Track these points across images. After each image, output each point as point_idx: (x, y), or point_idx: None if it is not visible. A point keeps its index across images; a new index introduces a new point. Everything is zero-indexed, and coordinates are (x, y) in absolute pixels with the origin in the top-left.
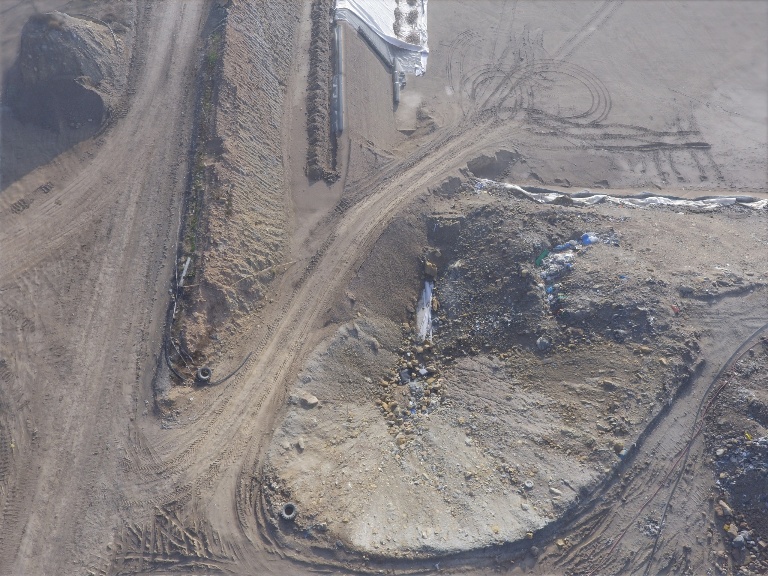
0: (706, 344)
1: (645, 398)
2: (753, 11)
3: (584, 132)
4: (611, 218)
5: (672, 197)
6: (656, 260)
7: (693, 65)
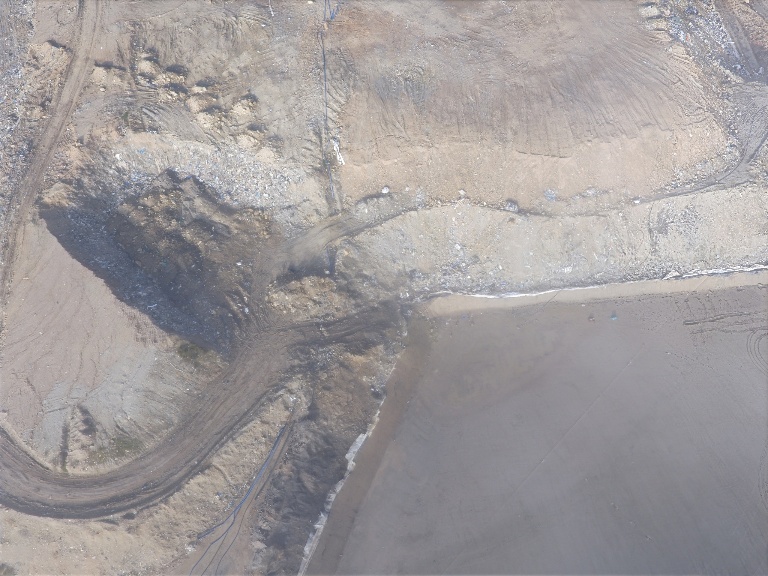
0: (747, 168)
1: (763, 153)
2: (655, 470)
3: (758, 324)
4: (765, 233)
5: (714, 274)
6: (760, 201)
7: (699, 395)
